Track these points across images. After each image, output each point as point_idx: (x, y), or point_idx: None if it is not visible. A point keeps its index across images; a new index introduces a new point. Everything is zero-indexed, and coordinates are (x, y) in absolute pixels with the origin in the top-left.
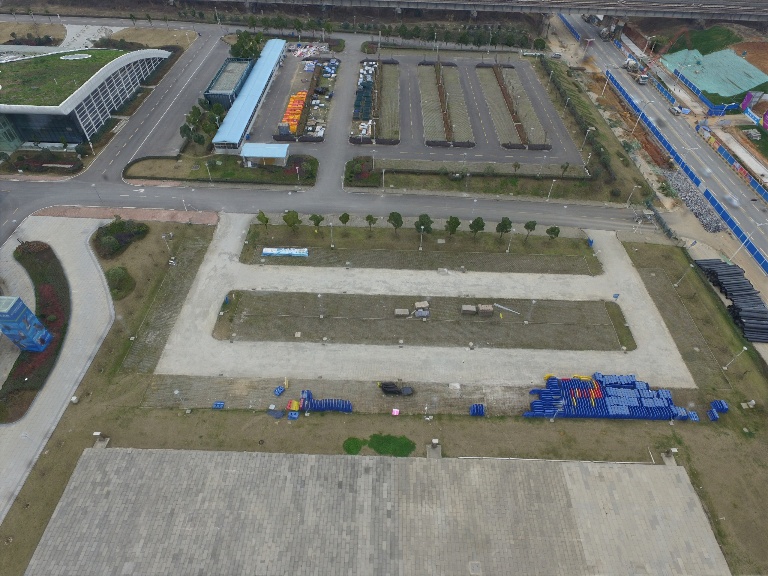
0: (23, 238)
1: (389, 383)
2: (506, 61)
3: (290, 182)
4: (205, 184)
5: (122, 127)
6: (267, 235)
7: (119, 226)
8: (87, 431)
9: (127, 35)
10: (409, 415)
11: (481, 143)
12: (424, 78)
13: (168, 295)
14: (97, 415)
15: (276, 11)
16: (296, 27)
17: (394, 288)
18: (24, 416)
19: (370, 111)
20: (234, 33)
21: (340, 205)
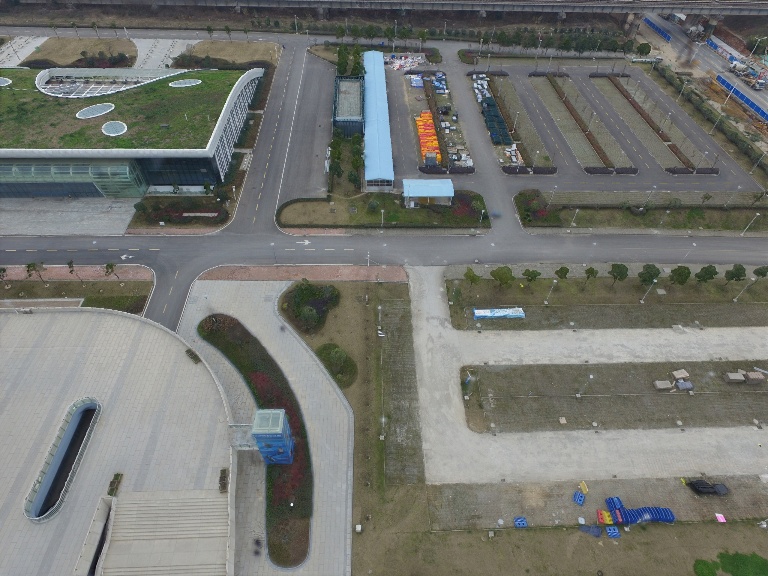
0: (200, 310)
1: (701, 481)
2: (617, 69)
3: (466, 225)
4: (373, 231)
5: (249, 163)
6: (470, 293)
7: (307, 291)
8: (391, 571)
9: (205, 50)
10: (738, 521)
11: (642, 168)
12: (543, 91)
13: (395, 376)
14: (391, 547)
15: (352, 17)
16: (389, 36)
17: (637, 353)
18: (308, 555)
19: (508, 134)
20: (319, 44)
21: (531, 251)
